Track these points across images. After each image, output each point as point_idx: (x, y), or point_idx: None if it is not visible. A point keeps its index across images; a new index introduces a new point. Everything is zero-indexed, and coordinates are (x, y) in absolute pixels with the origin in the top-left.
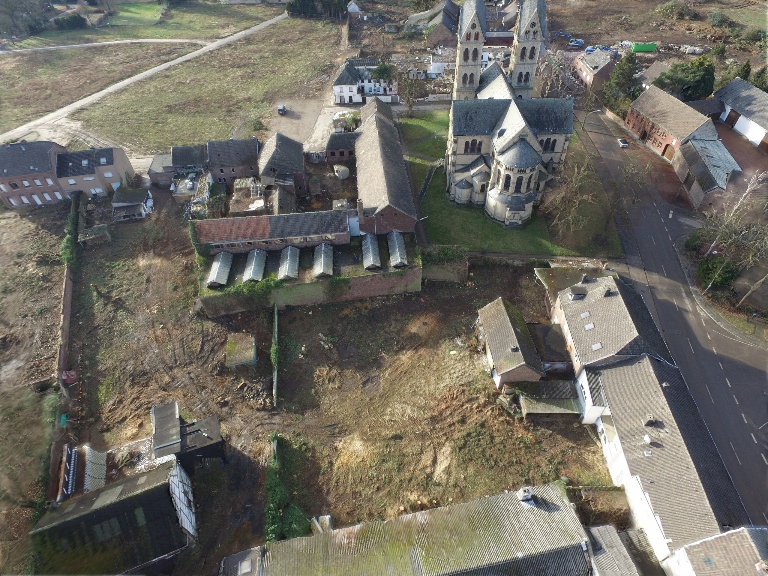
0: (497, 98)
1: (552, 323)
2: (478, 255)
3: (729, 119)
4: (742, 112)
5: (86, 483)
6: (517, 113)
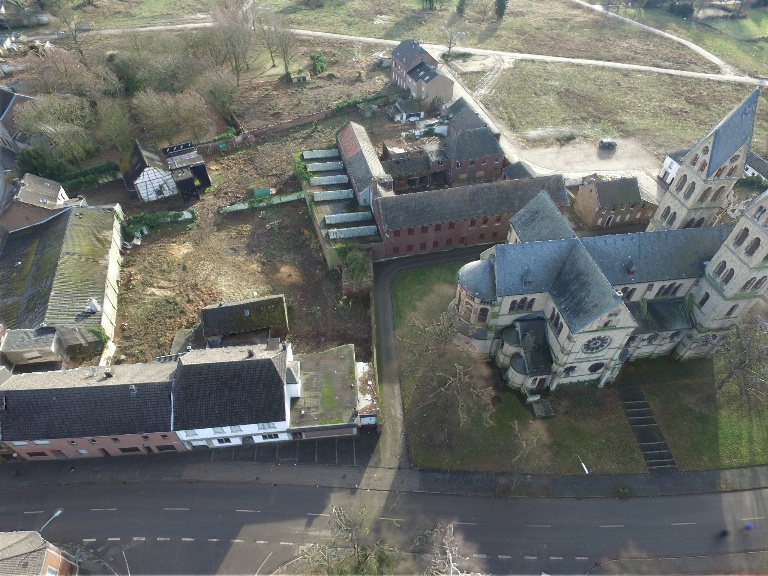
0: None
1: None
2: None
3: None
4: None
5: (175, 157)
6: None
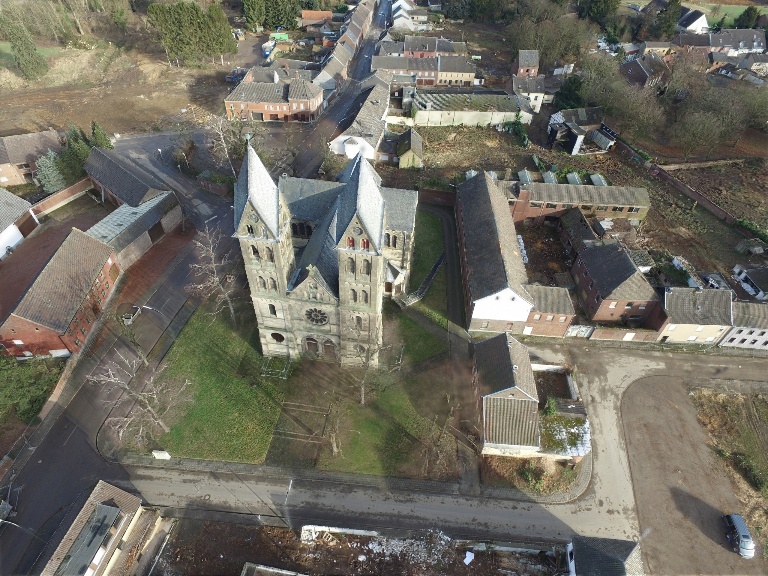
0: None
1: None
2: None
3: None
4: None
5: None
6: None
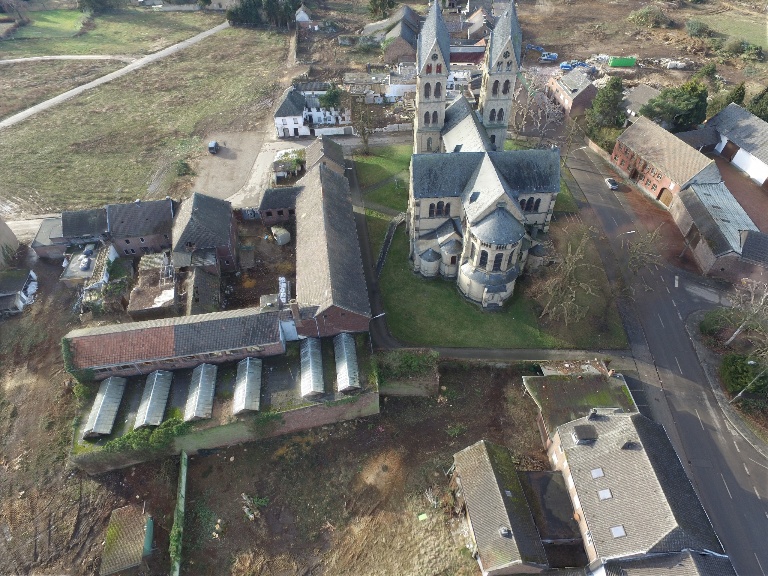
0: (467, 146)
1: (550, 461)
2: (451, 357)
3: (726, 151)
4: (742, 145)
5: None
6: (493, 173)
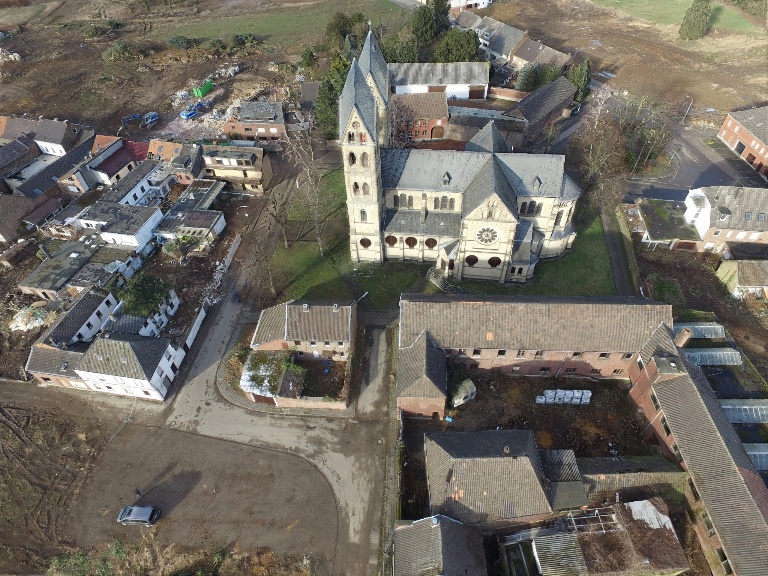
0: (457, 168)
1: None
2: None
3: None
4: (398, 83)
5: None
6: (530, 156)
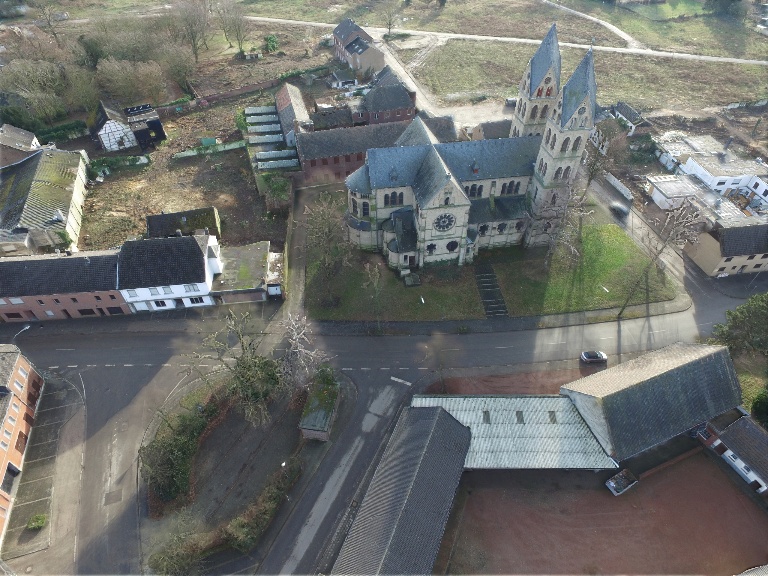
0: None
1: None
2: None
3: None
4: None
5: None
6: None
